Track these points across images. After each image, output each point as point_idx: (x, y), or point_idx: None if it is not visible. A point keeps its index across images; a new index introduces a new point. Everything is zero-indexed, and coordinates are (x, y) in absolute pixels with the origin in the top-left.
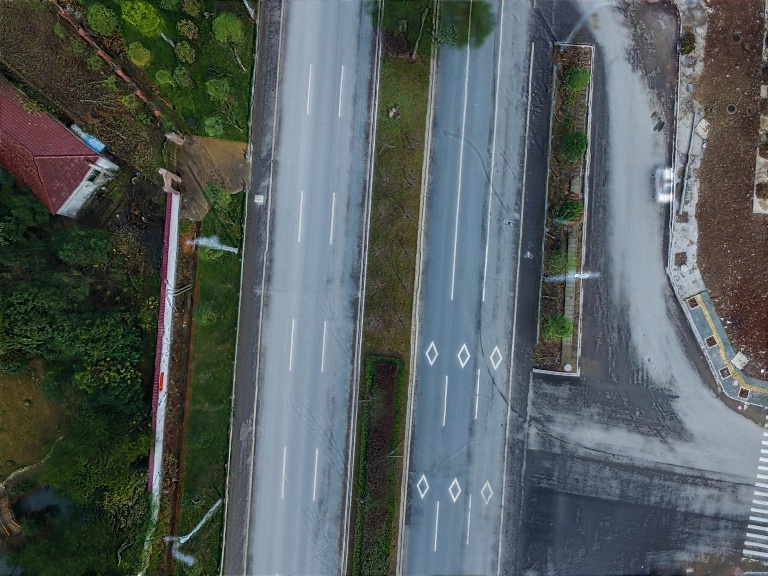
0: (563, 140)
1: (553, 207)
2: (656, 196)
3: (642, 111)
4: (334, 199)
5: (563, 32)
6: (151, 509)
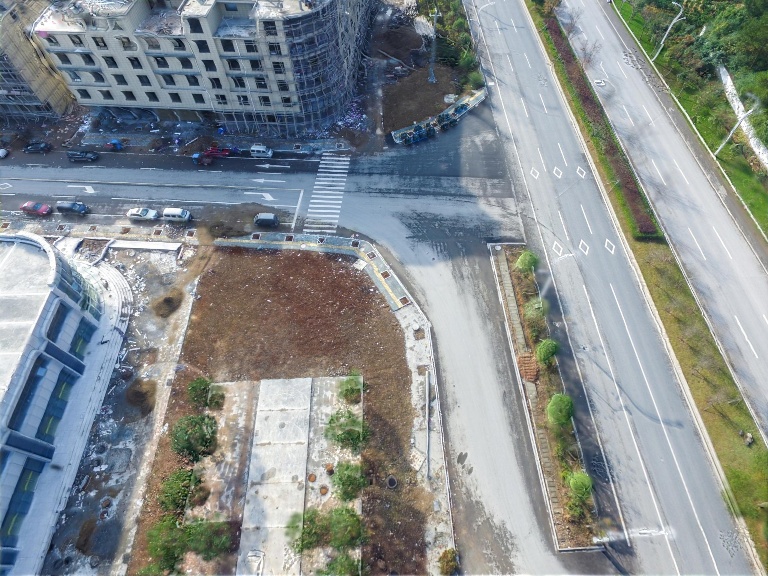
0: (559, 432)
1: (548, 367)
2: (452, 387)
3: (484, 474)
4: (754, 353)
5: (599, 565)
6: (762, 142)
